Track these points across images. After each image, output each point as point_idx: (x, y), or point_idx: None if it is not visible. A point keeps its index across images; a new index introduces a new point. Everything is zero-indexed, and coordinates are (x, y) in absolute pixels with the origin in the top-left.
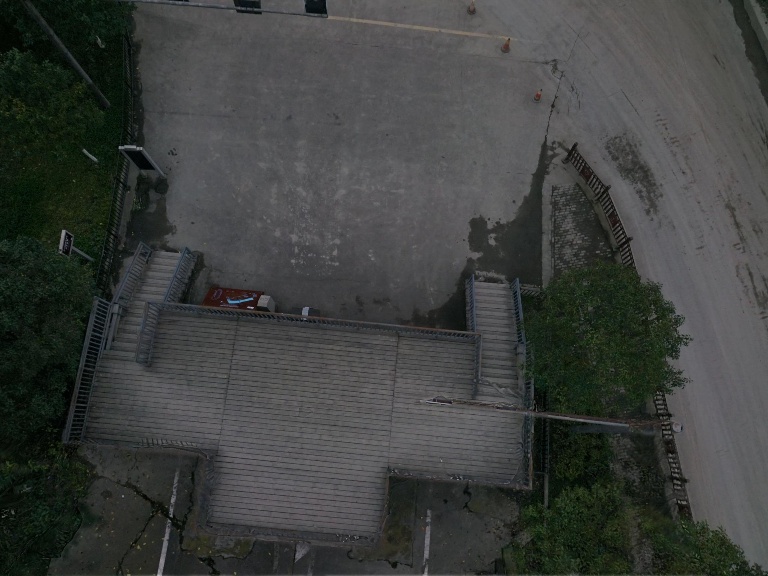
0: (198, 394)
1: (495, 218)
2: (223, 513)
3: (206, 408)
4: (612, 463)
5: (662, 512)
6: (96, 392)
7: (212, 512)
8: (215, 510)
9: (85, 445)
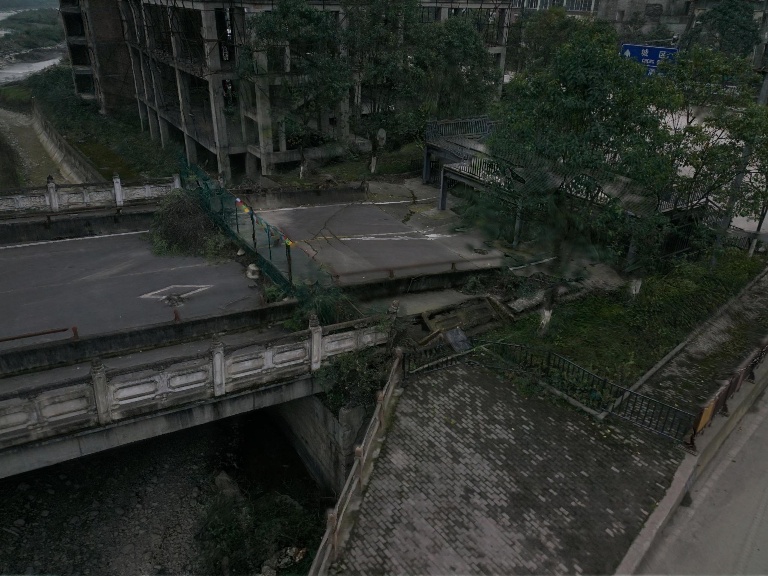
0: None
1: (742, 228)
2: None
3: None
4: (734, 295)
5: (763, 335)
6: None
7: (452, 164)
8: None
9: (410, 180)
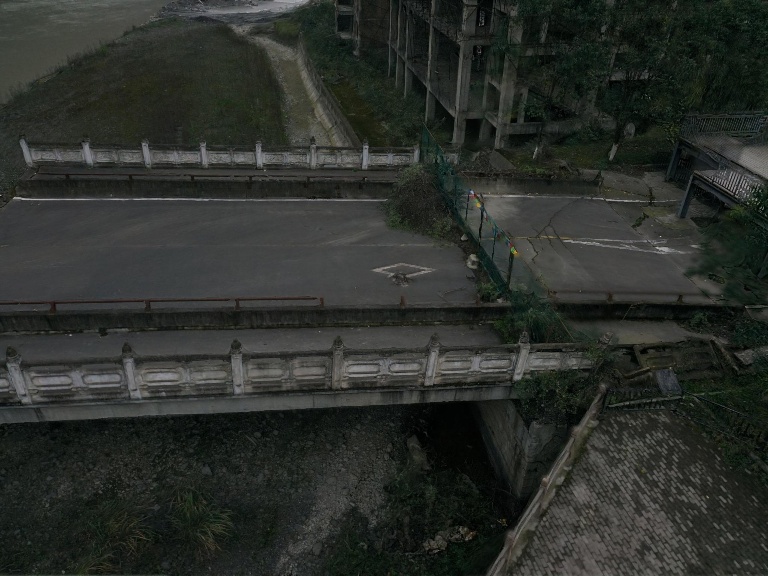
0: (758, 159)
1: None
2: (709, 174)
3: (755, 162)
4: None
5: None
6: (709, 136)
7: None
8: (707, 172)
9: (651, 174)
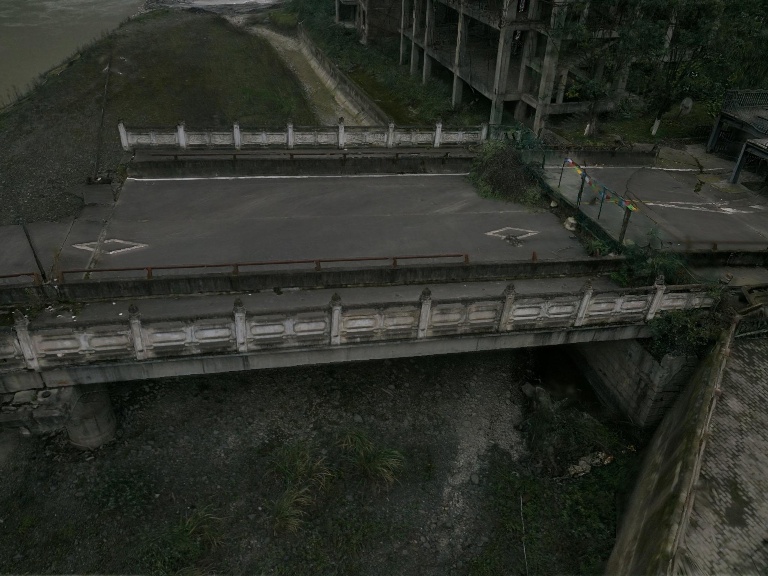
0: None
1: None
2: (762, 142)
3: None
4: None
5: None
6: (746, 110)
7: None
8: (758, 140)
9: (691, 146)
